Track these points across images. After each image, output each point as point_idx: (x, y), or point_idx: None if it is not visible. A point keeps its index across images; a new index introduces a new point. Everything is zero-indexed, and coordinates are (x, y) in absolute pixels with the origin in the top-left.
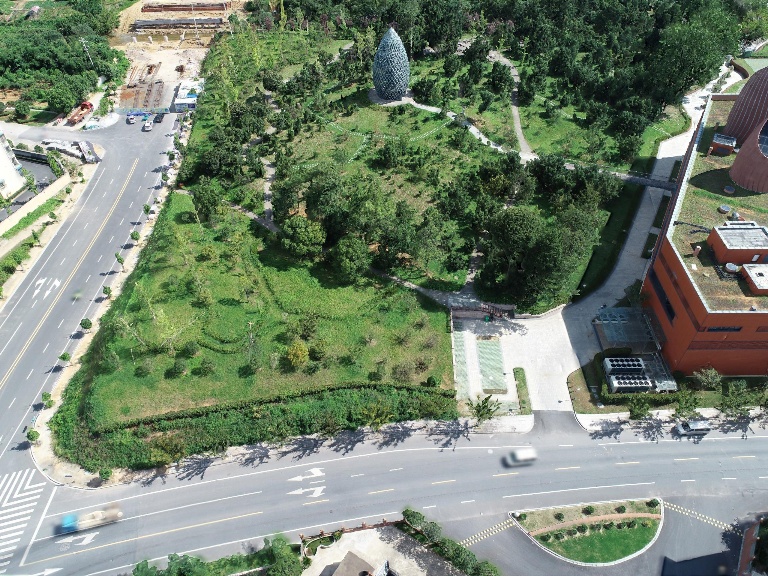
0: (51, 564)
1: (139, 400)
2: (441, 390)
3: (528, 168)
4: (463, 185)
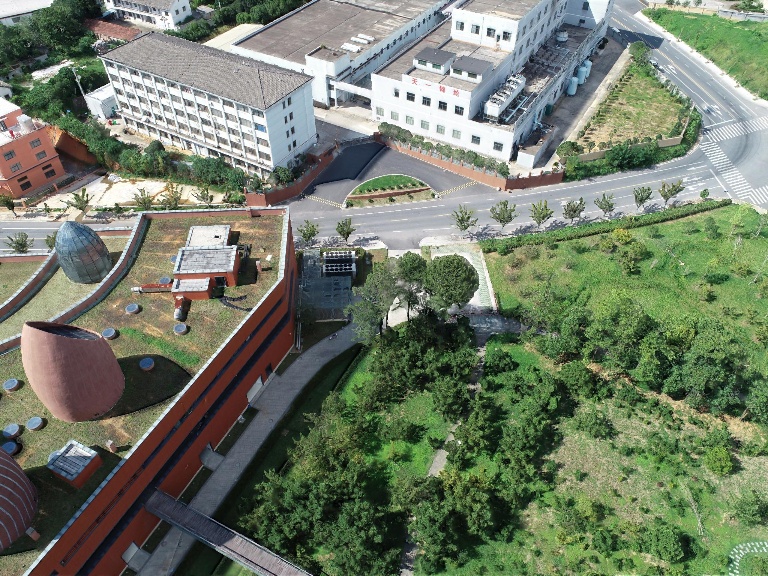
0: (695, 171)
1: (722, 216)
2: (496, 246)
3: (410, 482)
4: (514, 458)
